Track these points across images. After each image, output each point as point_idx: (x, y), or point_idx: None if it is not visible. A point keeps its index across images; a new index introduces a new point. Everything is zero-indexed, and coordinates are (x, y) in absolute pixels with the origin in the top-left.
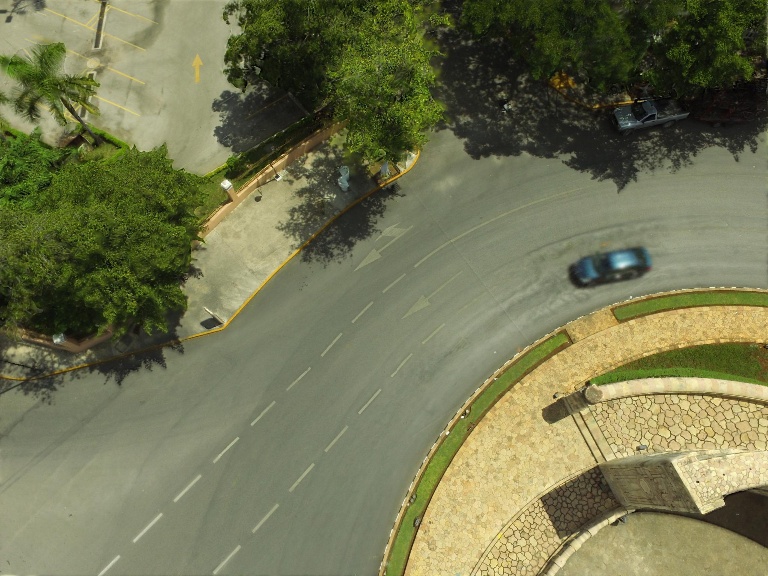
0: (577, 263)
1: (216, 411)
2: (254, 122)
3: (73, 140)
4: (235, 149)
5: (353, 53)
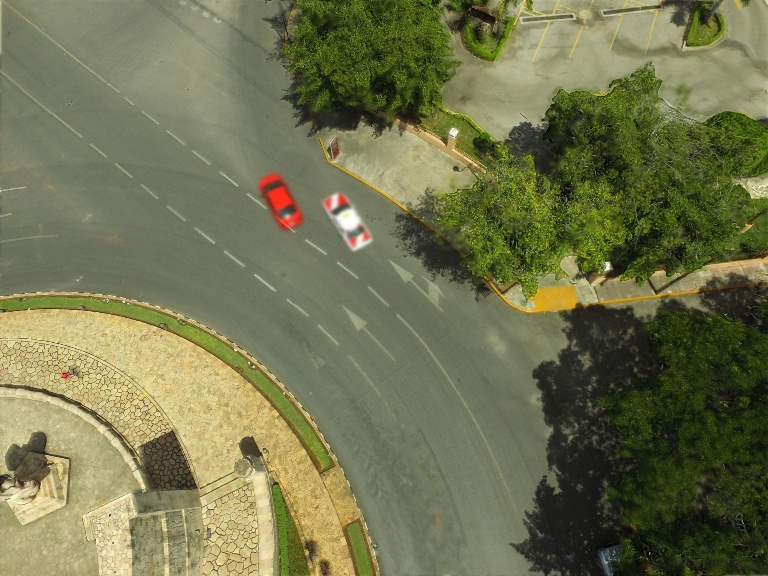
0: (413, 485)
1: (259, 167)
2: (541, 153)
3: (488, 14)
4: (508, 142)
5: (533, 165)
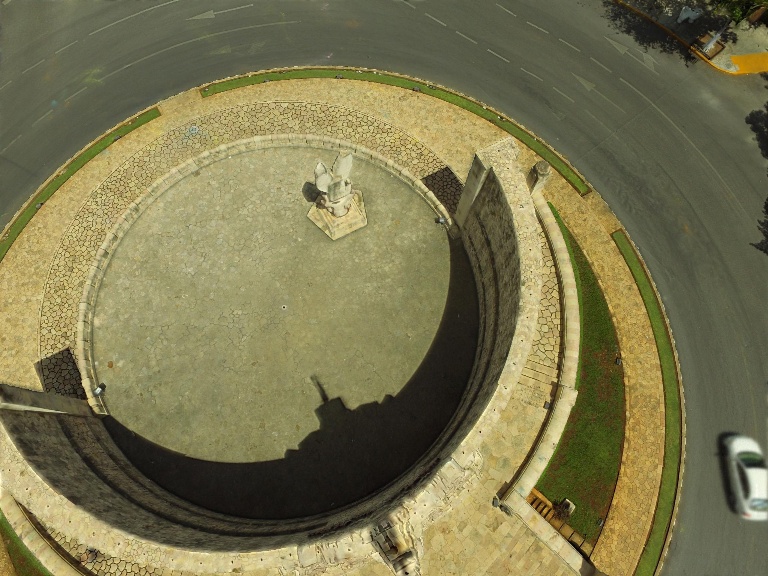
0: (660, 204)
1: None
2: None
3: None
4: None
5: None
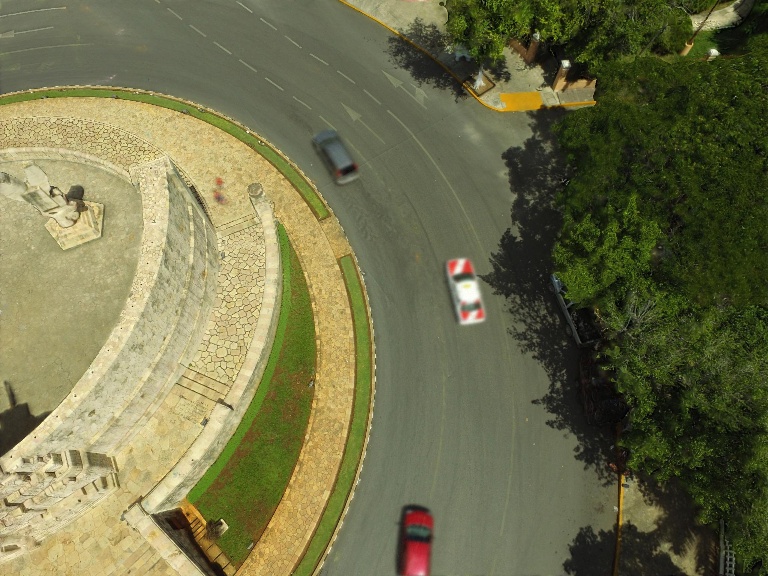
0: (397, 232)
1: None
2: None
3: None
4: None
5: None
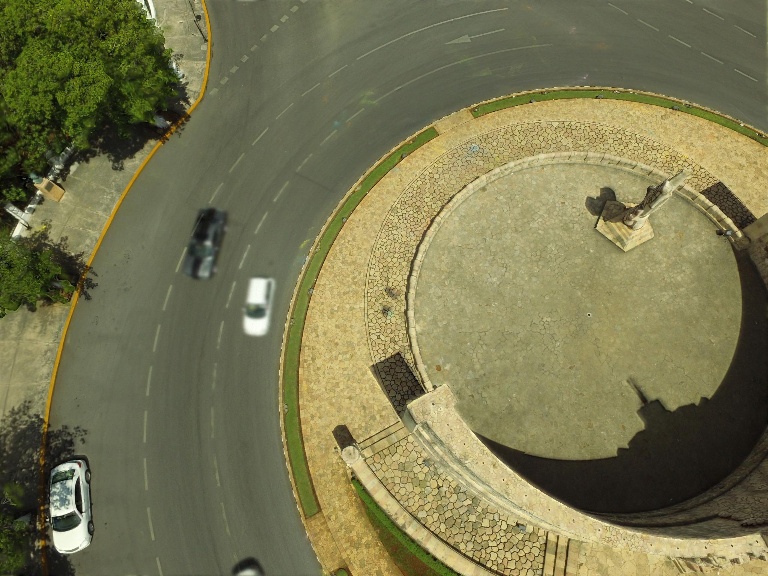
0: None
1: None
2: None
3: None
4: None
5: None
